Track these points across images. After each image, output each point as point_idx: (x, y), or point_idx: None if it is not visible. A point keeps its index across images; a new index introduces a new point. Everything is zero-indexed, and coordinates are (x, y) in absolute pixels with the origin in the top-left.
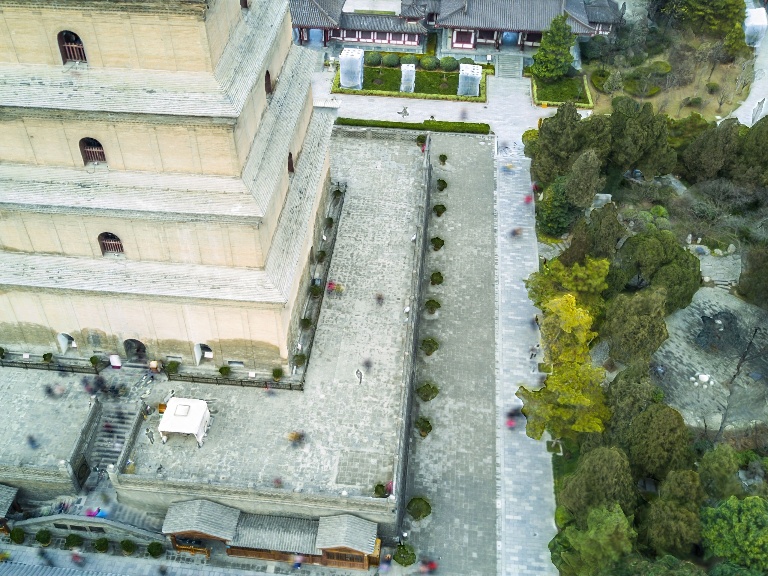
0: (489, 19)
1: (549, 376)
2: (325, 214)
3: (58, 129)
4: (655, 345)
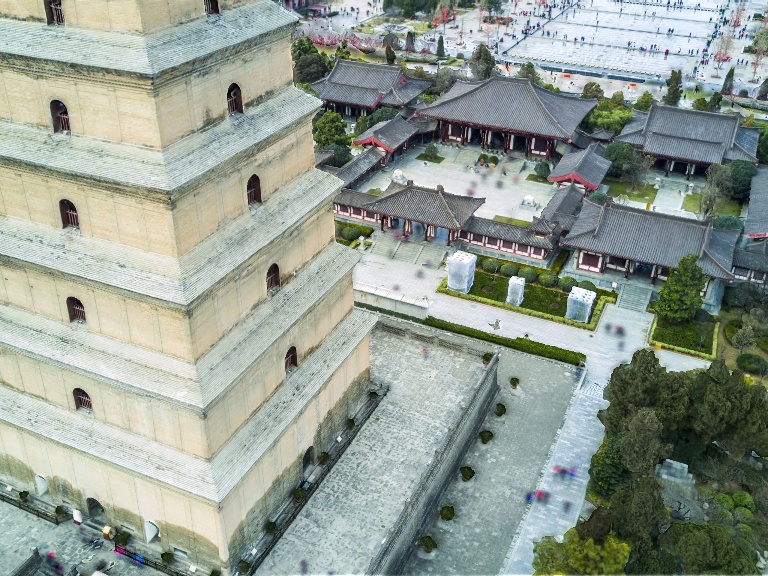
0: (618, 246)
1: None
2: (351, 414)
3: (51, 284)
4: None
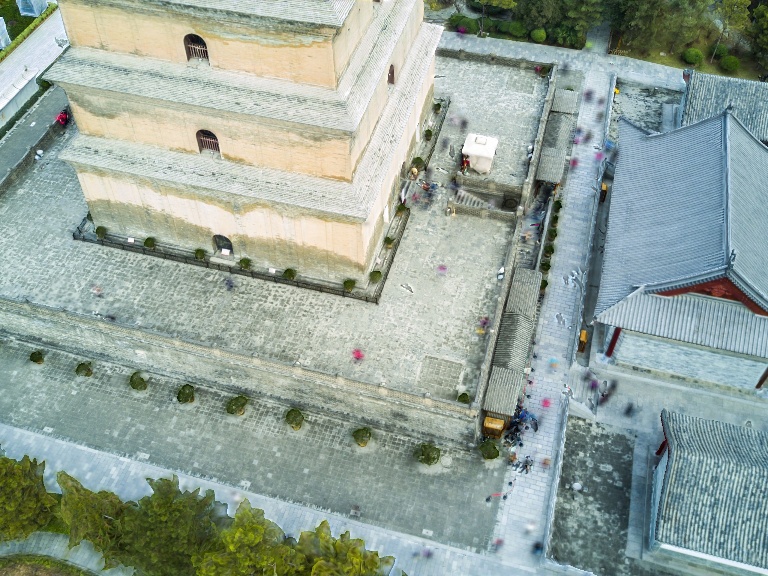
0: None
1: None
2: None
3: None
4: None
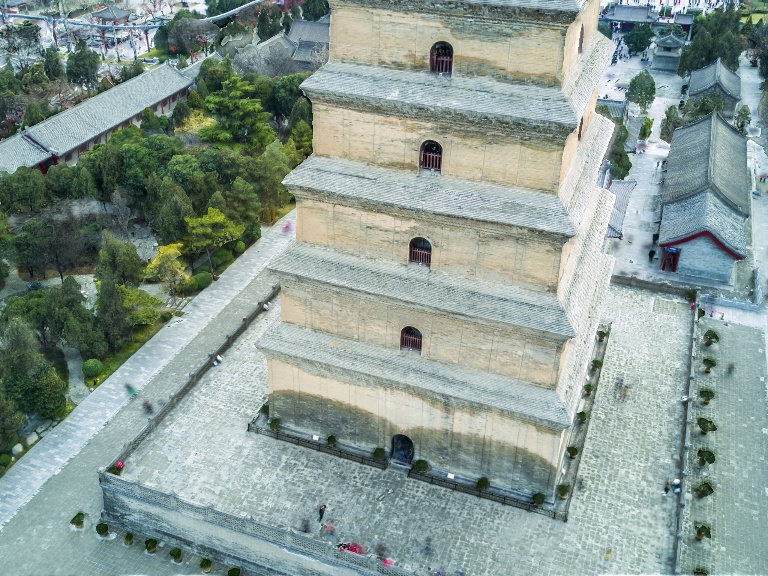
0: None
1: (219, 221)
2: None
3: None
4: None
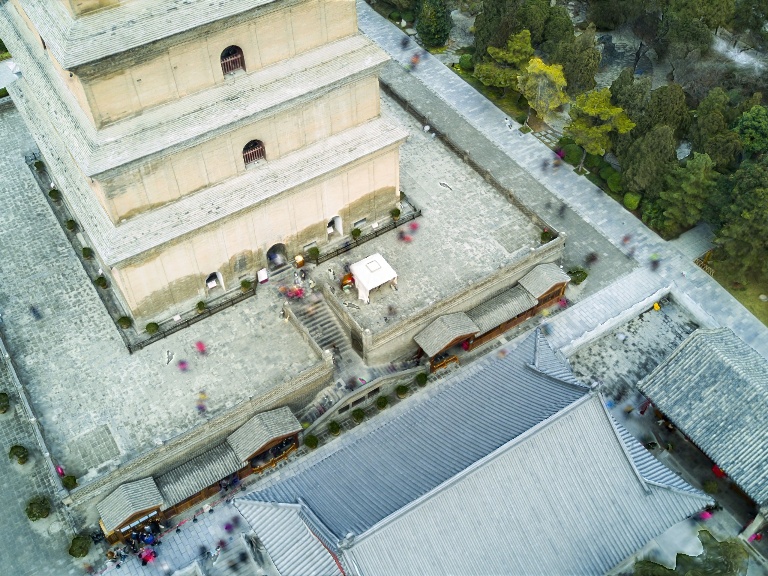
0: None
1: (583, 108)
2: None
3: (203, 48)
4: (596, 70)
